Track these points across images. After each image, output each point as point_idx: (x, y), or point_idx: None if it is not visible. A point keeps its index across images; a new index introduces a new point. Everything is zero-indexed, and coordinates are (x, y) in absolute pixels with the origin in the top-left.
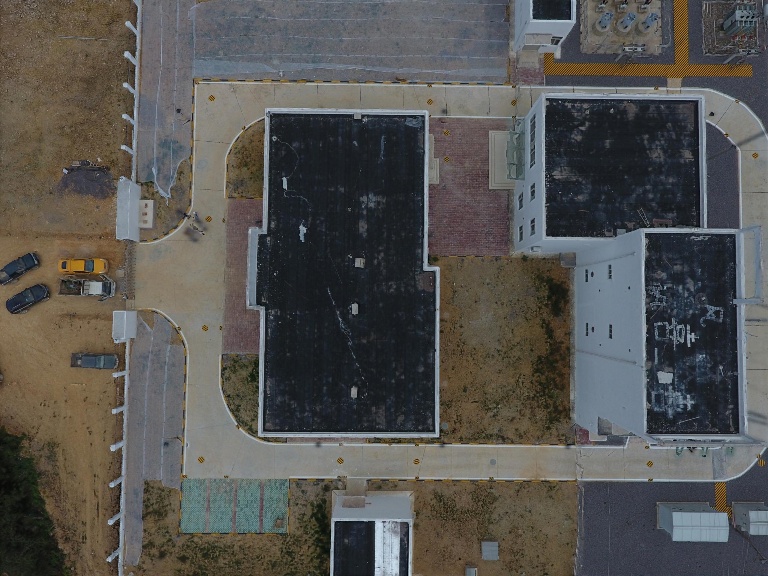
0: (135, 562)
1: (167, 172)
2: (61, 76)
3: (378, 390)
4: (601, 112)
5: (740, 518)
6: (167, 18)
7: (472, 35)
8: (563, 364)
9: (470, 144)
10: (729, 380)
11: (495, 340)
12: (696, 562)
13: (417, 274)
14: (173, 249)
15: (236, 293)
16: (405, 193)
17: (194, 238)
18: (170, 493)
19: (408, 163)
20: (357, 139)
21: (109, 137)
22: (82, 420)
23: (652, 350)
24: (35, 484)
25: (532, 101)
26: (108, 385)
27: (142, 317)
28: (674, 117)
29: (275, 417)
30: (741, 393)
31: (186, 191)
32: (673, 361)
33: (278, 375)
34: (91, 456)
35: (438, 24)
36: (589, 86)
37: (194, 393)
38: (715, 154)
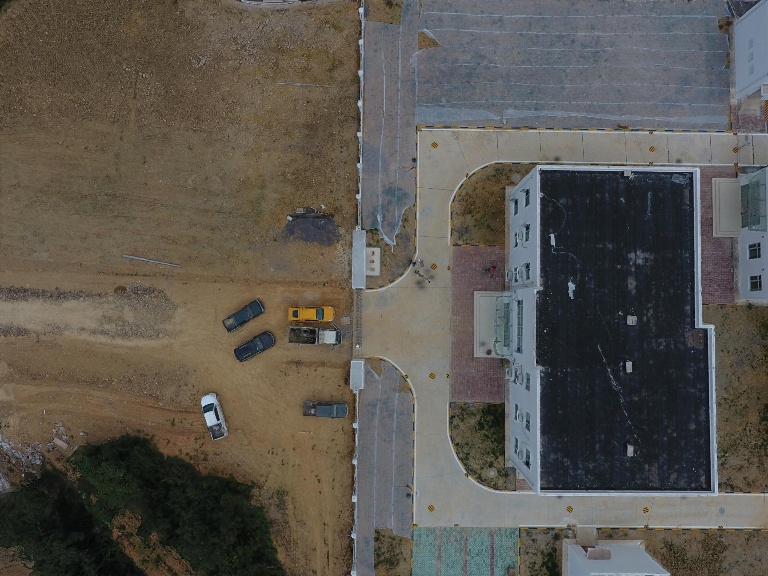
0: None
1: (392, 219)
2: (282, 122)
3: (650, 448)
4: None
5: None
6: (389, 65)
7: (693, 82)
8: None
9: None
10: None
11: (722, 388)
12: None
13: (686, 331)
14: (399, 297)
15: (462, 341)
16: (673, 250)
17: (419, 285)
18: (401, 542)
19: (675, 220)
20: (624, 196)
21: (332, 184)
22: (310, 468)
23: None
24: (268, 533)
25: (754, 148)
26: (336, 433)
27: (370, 365)
28: None
29: (548, 475)
30: None
31: (411, 238)
32: None
33: (550, 432)
34: (320, 504)
35: (659, 71)
36: None
37: (423, 441)
38: None
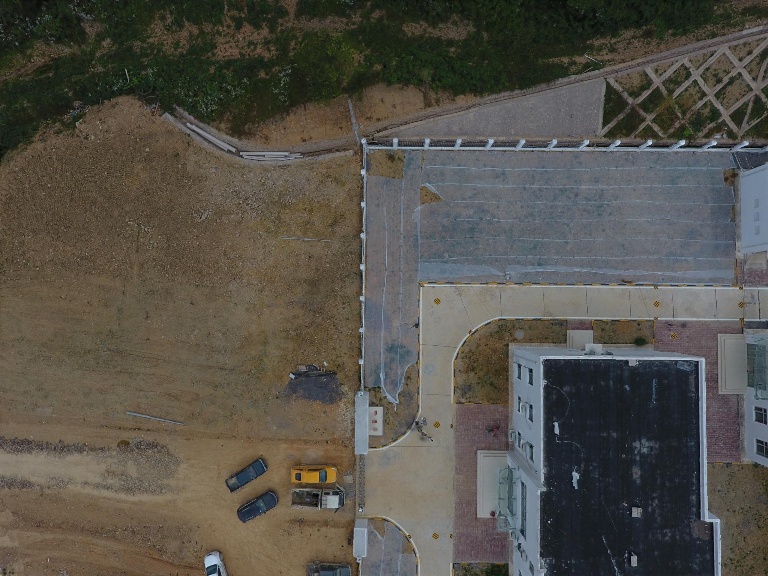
0: None
1: (394, 377)
2: (285, 278)
3: None
4: None
5: None
6: (391, 220)
7: (698, 236)
8: None
9: (698, 347)
10: None
11: (728, 548)
12: None
13: (692, 521)
14: (402, 455)
15: (466, 500)
16: (678, 438)
17: (422, 444)
18: None
19: (680, 407)
20: (628, 383)
21: (335, 341)
22: None
23: None
24: None
25: (760, 303)
26: None
27: (373, 525)
28: None
29: None
30: None
31: (414, 396)
32: None
33: None
34: None
35: (664, 225)
36: None
37: None
38: None
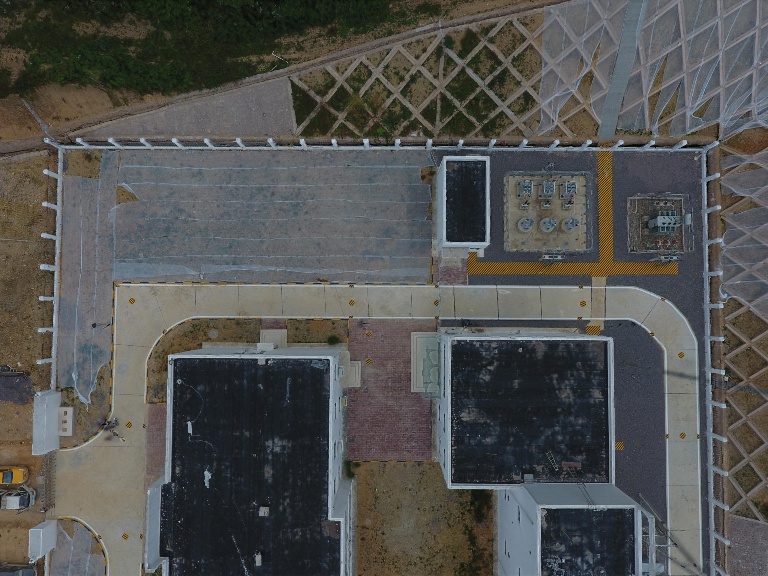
0: None
1: (87, 377)
2: None
3: None
4: (510, 351)
5: None
6: (87, 220)
7: (394, 234)
8: (486, 571)
9: (392, 346)
10: None
11: (417, 547)
12: None
13: (323, 520)
14: (93, 456)
15: None
16: (311, 437)
17: (114, 444)
18: None
19: (314, 406)
20: (262, 382)
21: (29, 341)
22: None
23: None
24: None
25: (455, 301)
26: None
27: (62, 526)
28: (584, 356)
29: None
30: None
31: (106, 397)
32: None
33: None
34: None
35: (360, 223)
36: (513, 285)
37: None
38: (640, 354)
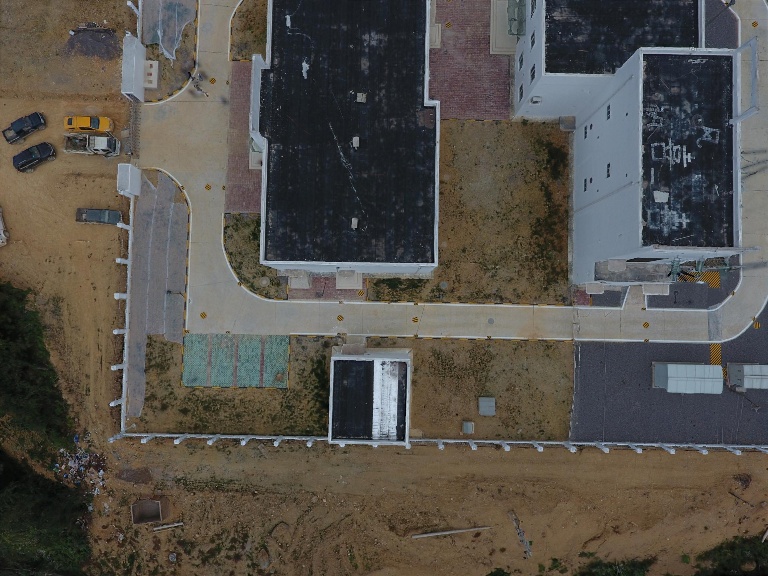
0: (137, 414)
1: (172, 34)
2: None
3: (378, 223)
4: None
5: (735, 376)
6: None
7: None
8: (561, 226)
9: (472, 10)
10: (724, 199)
11: (494, 202)
12: (690, 421)
13: (418, 111)
14: (177, 110)
15: (239, 153)
16: (407, 32)
17: (198, 99)
18: (172, 347)
19: (410, 2)
20: None
21: (115, 0)
22: (86, 276)
23: (648, 170)
24: (40, 336)
25: None
26: (112, 242)
27: (146, 176)
28: None
29: (276, 248)
30: (736, 209)
31: (191, 53)
32: (669, 181)
33: (280, 207)
34: (95, 311)
35: None
36: None
37: (197, 250)
38: (715, 22)
